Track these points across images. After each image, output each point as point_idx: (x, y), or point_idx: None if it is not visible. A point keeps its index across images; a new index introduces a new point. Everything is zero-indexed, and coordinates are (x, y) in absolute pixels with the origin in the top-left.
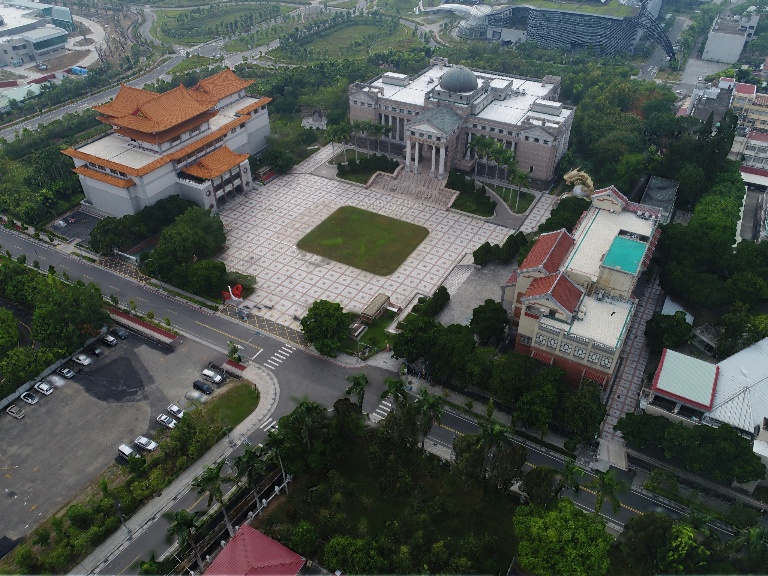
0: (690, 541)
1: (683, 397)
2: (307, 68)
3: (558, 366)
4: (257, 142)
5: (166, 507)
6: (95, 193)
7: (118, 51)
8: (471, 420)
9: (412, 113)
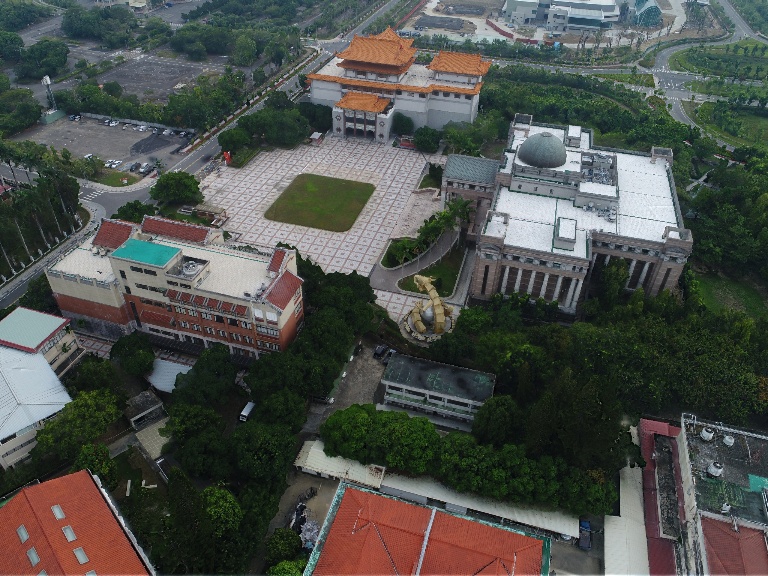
0: None
1: (1, 320)
2: (642, 115)
3: None
4: None
5: None
6: None
7: None
8: None
9: None
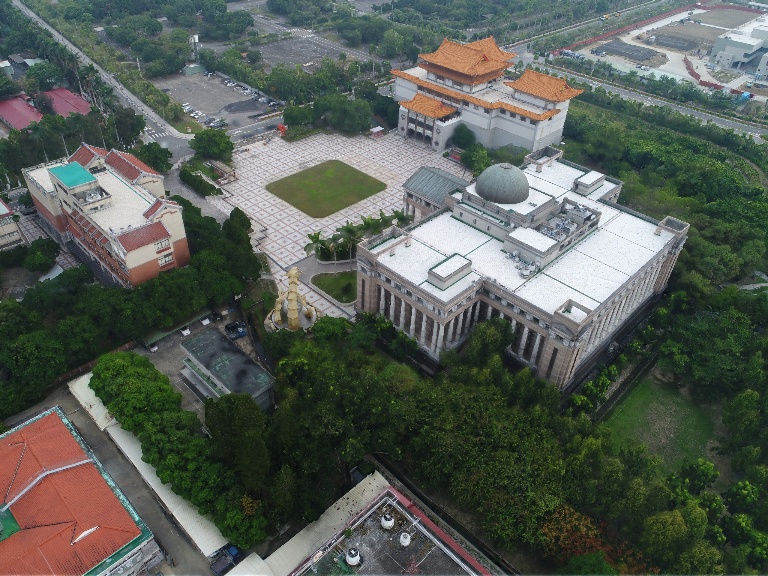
0: None
1: None
2: None
3: None
4: None
5: None
6: None
7: None
8: None
9: None
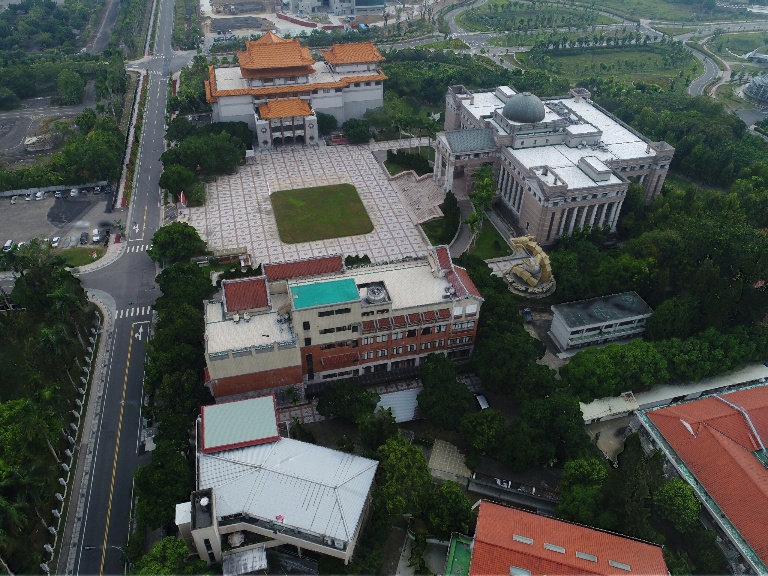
0: None
1: (203, 427)
2: (501, 71)
3: None
4: (363, 112)
5: None
6: None
7: (410, 21)
8: None
9: None
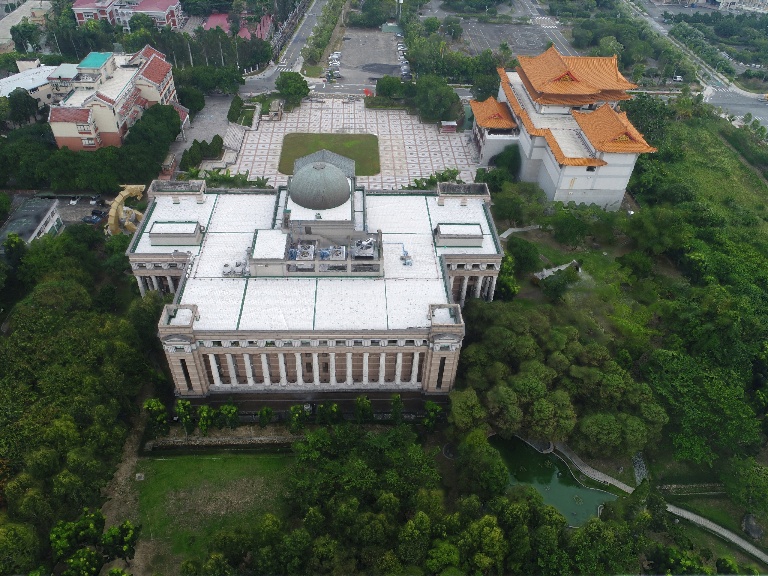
0: None
1: None
2: None
3: None
4: None
5: None
6: None
7: None
8: None
9: None
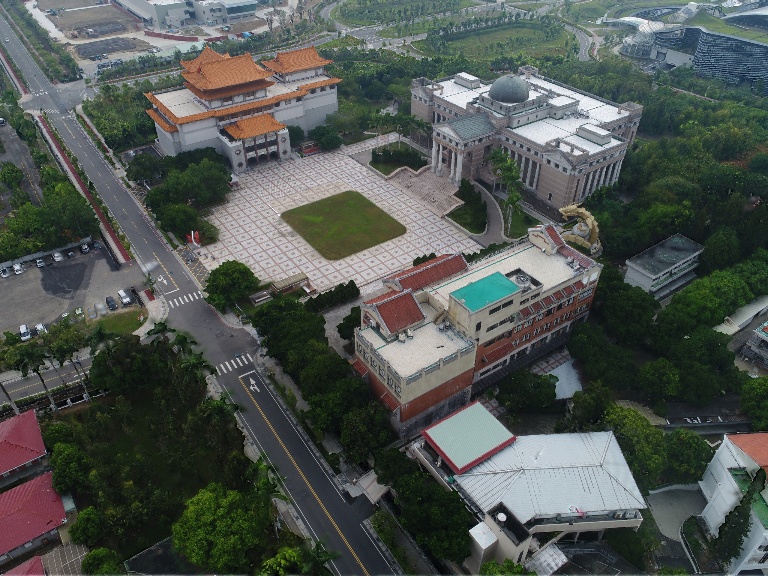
0: (278, 568)
1: (442, 450)
2: (422, 60)
3: (371, 381)
4: (321, 118)
5: (13, 380)
6: (159, 133)
7: None
8: (281, 404)
9: (458, 116)
